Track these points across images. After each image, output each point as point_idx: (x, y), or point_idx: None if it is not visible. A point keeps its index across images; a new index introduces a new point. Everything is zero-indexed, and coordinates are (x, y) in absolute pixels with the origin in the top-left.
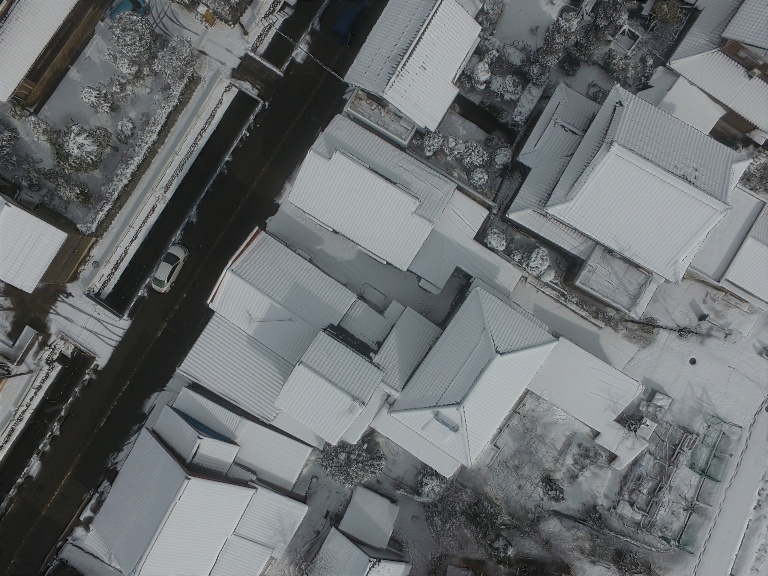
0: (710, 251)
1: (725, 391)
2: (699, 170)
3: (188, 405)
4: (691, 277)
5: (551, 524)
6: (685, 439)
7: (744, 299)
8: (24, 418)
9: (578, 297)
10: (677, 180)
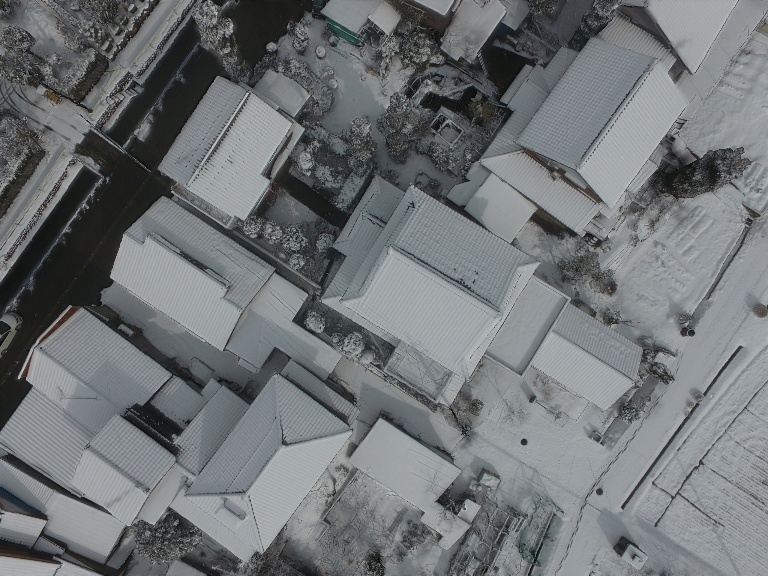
0: (515, 344)
1: (556, 473)
2: (480, 274)
3: (1, 476)
4: None
5: None
6: (512, 521)
7: (564, 386)
8: None
9: None
10: (450, 286)
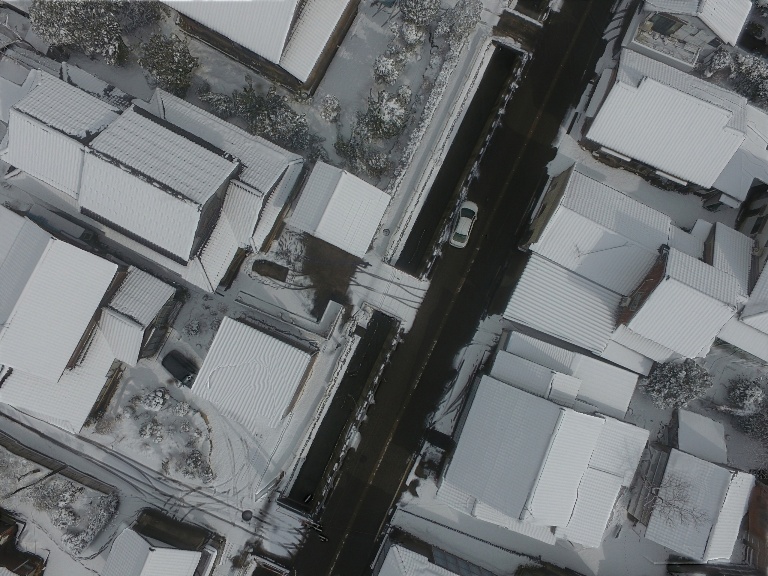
0: None
1: None
2: None
3: (520, 348)
4: None
5: None
6: None
7: None
8: (332, 393)
9: None
10: None
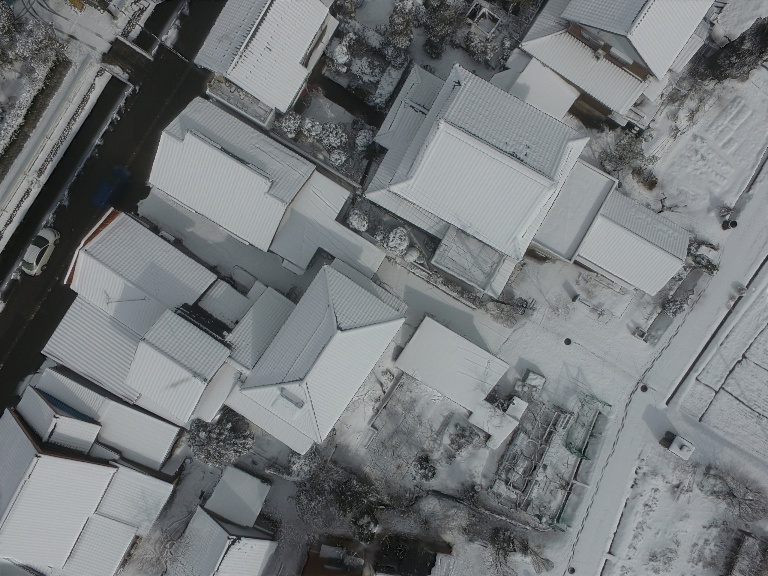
0: (563, 230)
1: (600, 371)
2: (531, 147)
3: (51, 386)
4: (553, 257)
5: (431, 504)
6: (559, 418)
7: (609, 279)
8: None
9: (443, 277)
10: (503, 156)
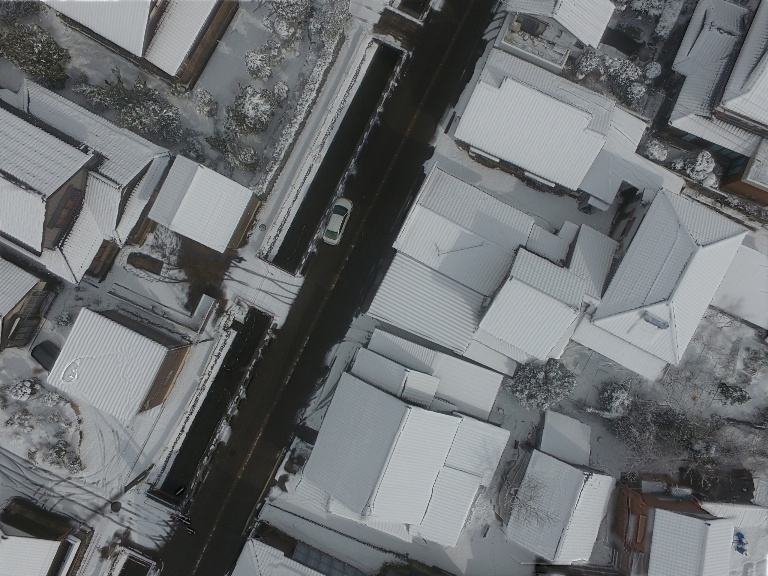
0: None
1: None
2: None
3: (382, 346)
4: None
5: (728, 432)
6: None
7: None
8: (206, 387)
9: (738, 199)
10: None
